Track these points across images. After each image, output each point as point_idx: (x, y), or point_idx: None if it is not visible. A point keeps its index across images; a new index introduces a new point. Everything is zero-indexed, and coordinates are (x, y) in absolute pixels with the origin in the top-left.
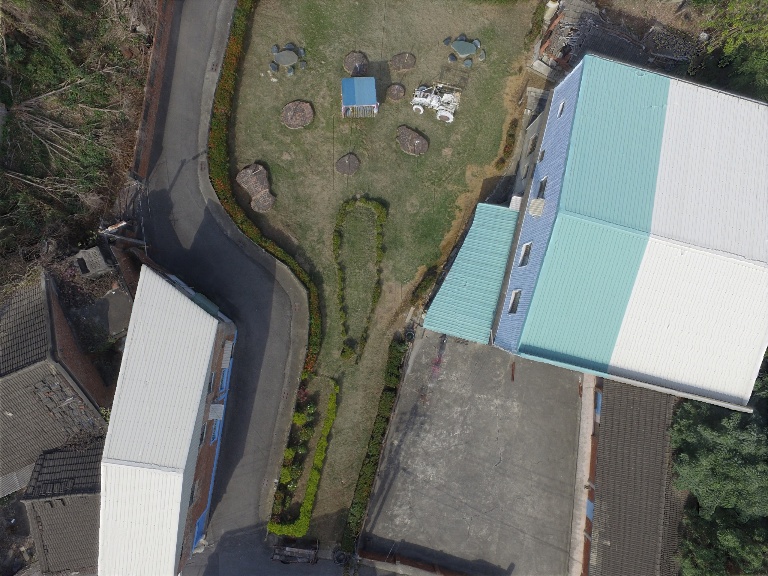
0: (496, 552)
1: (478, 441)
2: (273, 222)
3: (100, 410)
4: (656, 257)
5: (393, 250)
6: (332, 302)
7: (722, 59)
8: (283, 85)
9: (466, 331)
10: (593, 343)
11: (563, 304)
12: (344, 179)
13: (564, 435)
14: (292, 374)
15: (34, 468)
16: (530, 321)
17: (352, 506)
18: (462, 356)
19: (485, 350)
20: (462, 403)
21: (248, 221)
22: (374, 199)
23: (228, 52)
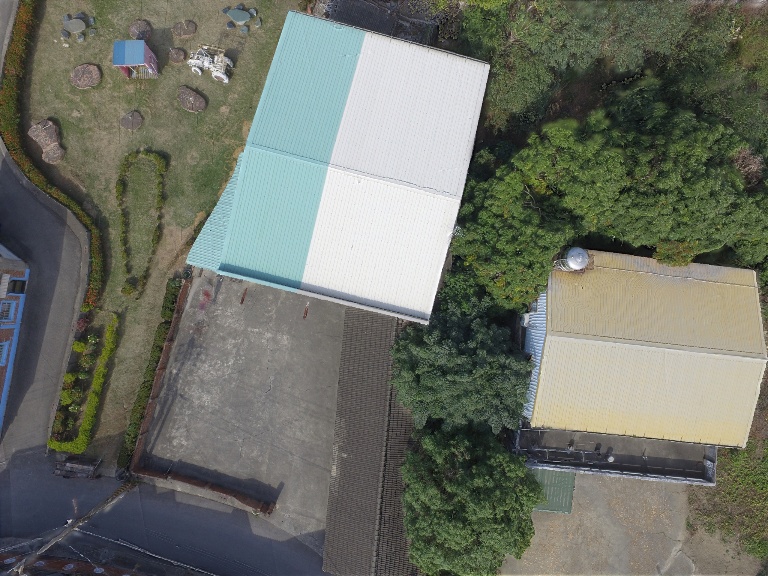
0: (266, 472)
1: (250, 370)
2: (64, 172)
3: None
4: (336, 185)
5: (174, 198)
6: (117, 244)
7: (463, 21)
8: (74, 50)
9: None
10: (286, 262)
11: (256, 227)
12: (129, 134)
13: (331, 366)
14: None
15: None
16: (227, 242)
17: (128, 427)
18: (236, 293)
19: (258, 288)
20: (236, 336)
21: (35, 170)
22: (156, 152)
23: (18, 20)
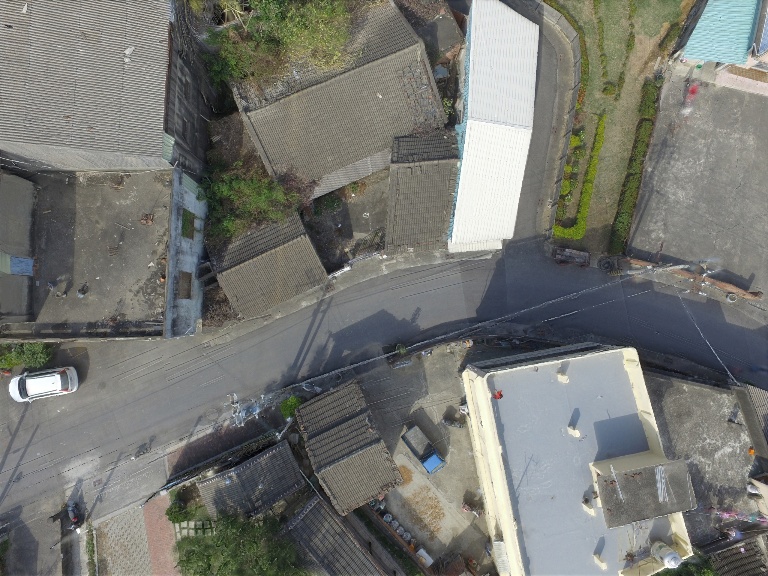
0: (738, 263)
1: (720, 168)
2: None
3: (443, 101)
4: None
5: (641, 9)
6: (592, 51)
7: None
8: None
9: (724, 55)
10: None
11: None
12: None
13: None
14: (559, 113)
15: (393, 146)
16: None
17: (620, 215)
18: (704, 97)
19: (723, 92)
20: (705, 136)
21: None
22: None
23: None
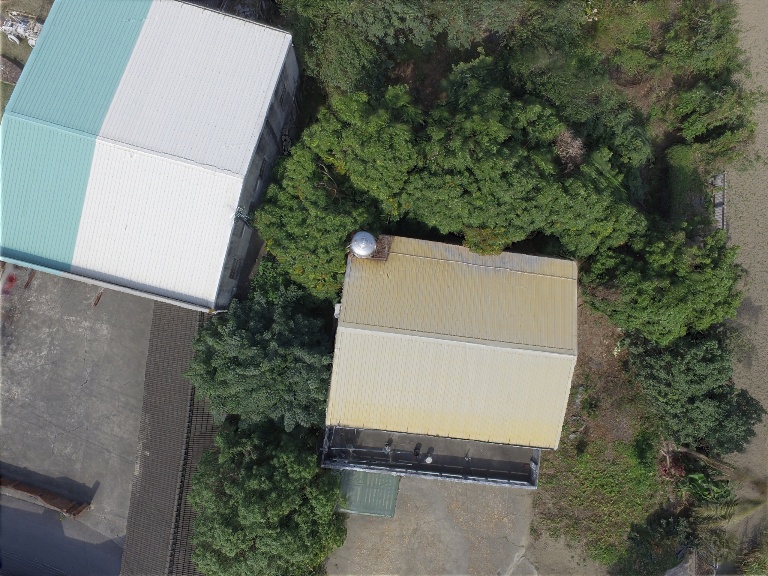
0: (81, 470)
1: (65, 361)
2: None
3: None
4: (105, 159)
5: None
6: None
7: None
8: None
9: None
10: (53, 243)
11: (18, 204)
12: None
13: None
14: None
15: None
16: None
17: None
18: (53, 279)
19: None
20: (50, 324)
21: None
22: None
23: None
